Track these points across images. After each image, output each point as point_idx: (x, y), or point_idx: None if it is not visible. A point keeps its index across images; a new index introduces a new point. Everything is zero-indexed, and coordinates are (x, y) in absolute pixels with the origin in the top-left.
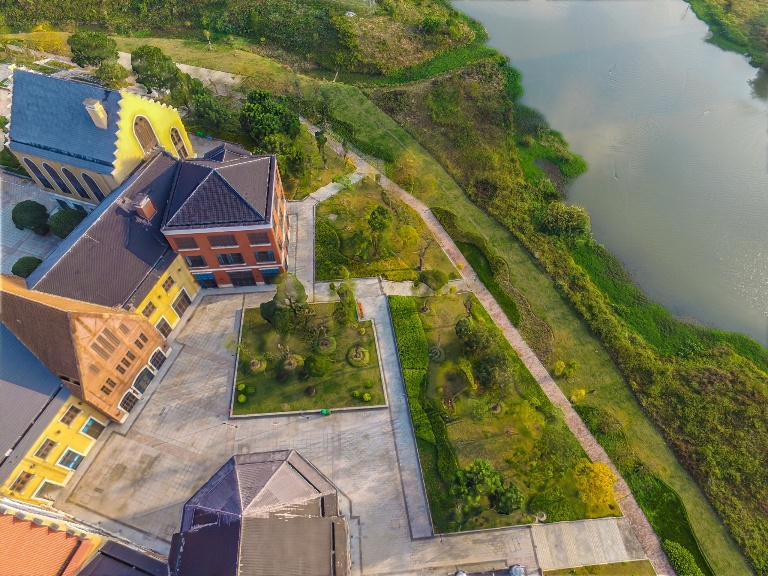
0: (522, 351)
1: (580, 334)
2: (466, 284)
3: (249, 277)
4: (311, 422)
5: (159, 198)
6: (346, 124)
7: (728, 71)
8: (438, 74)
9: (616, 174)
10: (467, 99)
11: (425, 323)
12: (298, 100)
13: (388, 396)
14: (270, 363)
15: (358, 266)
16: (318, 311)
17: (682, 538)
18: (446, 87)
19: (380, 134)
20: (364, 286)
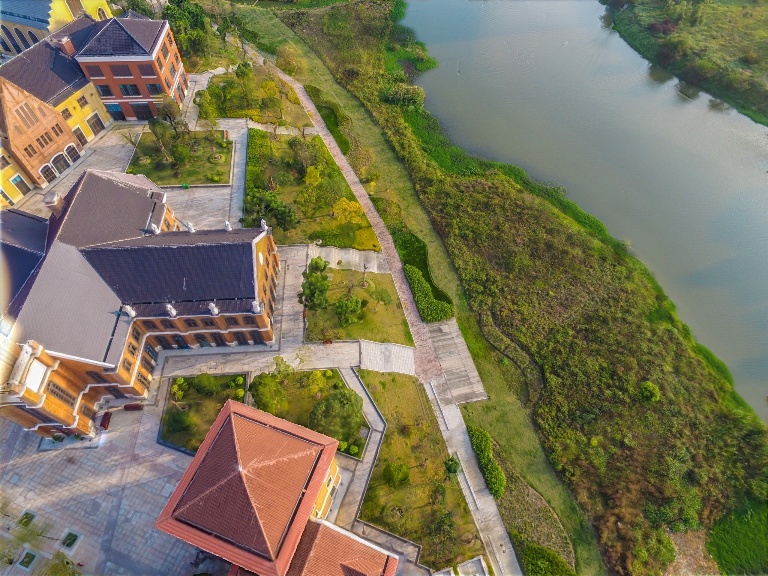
0: (344, 168)
1: (391, 160)
2: (316, 130)
3: (148, 111)
4: (175, 192)
5: (79, 44)
6: (253, 32)
7: (582, 8)
8: (339, 2)
9: (459, 71)
10: (356, 19)
11: None
12: (217, 14)
13: (233, 180)
14: (153, 160)
15: (232, 111)
16: (196, 135)
17: (419, 264)
18: (341, 10)
19: (279, 40)
20: (234, 123)
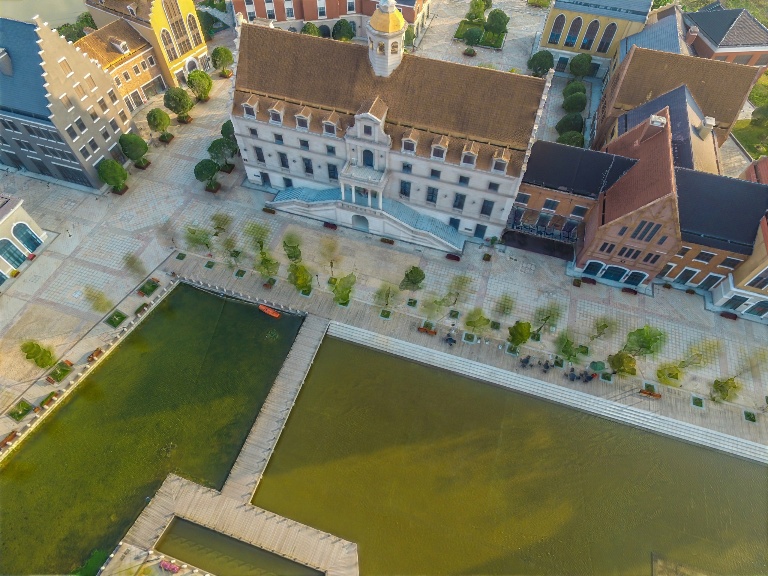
0: None
1: None
2: None
3: None
4: None
5: None
6: None
7: None
8: None
9: None
10: (757, 7)
11: None
12: None
13: None
14: (767, 148)
15: None
16: None
17: None
18: None
19: None
20: None
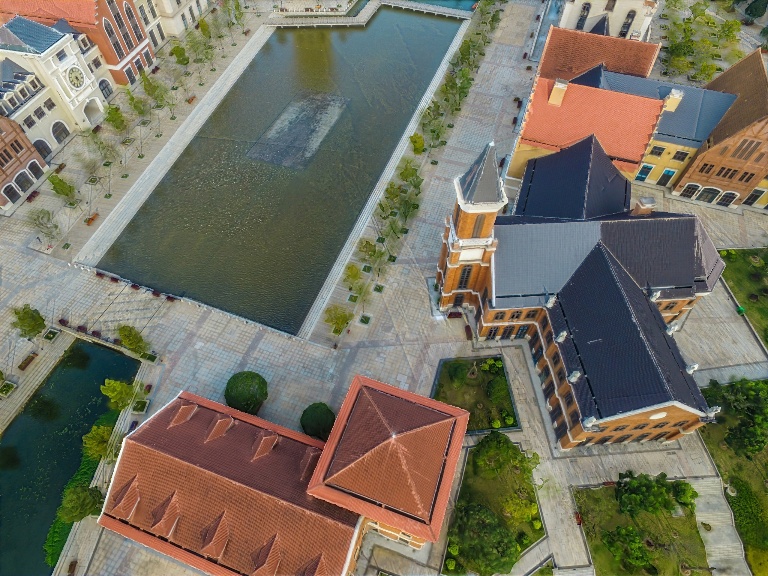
0: None
1: None
2: None
3: None
4: (726, 302)
5: None
6: None
7: None
8: None
9: None
10: None
11: None
12: None
13: None
14: (761, 269)
15: None
16: None
17: None
18: None
19: None
20: None
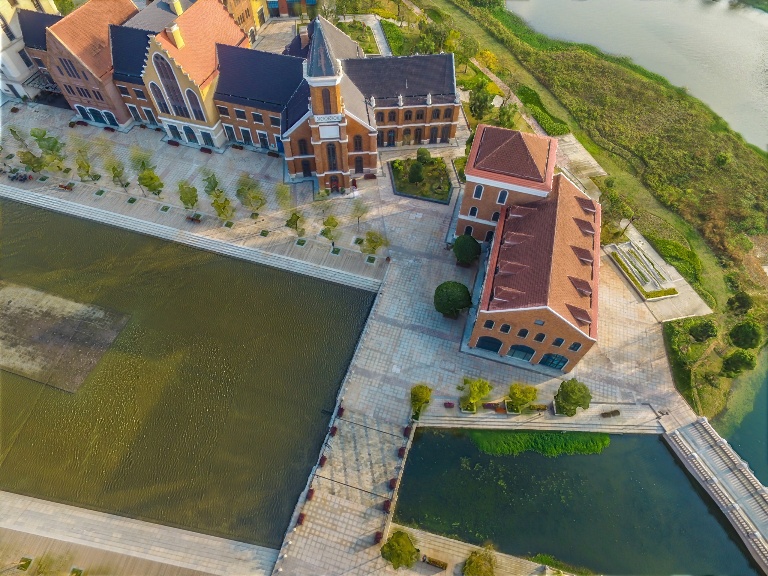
0: None
1: (492, 42)
2: None
3: (298, 8)
4: None
5: None
6: None
7: None
8: None
9: None
10: None
11: (402, 31)
12: None
13: (381, 52)
14: None
15: (362, 9)
16: None
17: (535, 103)
18: None
19: None
20: (366, 17)
